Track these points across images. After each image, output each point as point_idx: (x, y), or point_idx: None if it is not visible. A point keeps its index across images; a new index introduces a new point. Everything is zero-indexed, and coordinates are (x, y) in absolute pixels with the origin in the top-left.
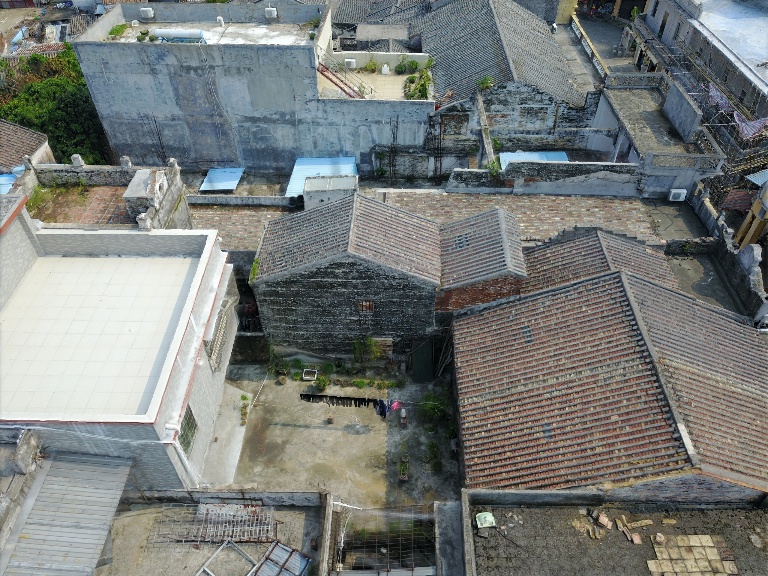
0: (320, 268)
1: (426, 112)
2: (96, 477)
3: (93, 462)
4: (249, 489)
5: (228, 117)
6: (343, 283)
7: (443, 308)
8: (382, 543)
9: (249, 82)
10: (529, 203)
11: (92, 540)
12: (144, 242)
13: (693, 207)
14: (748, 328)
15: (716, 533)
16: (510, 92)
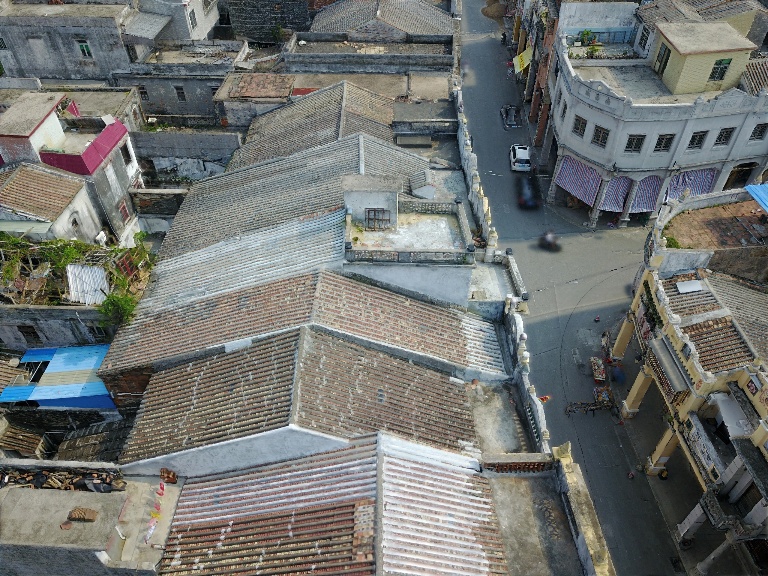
0: None
1: None
2: None
3: (158, 15)
4: None
5: None
6: None
7: (312, 8)
8: None
9: None
10: None
11: (158, 27)
12: None
13: None
14: (448, 16)
15: None
16: None
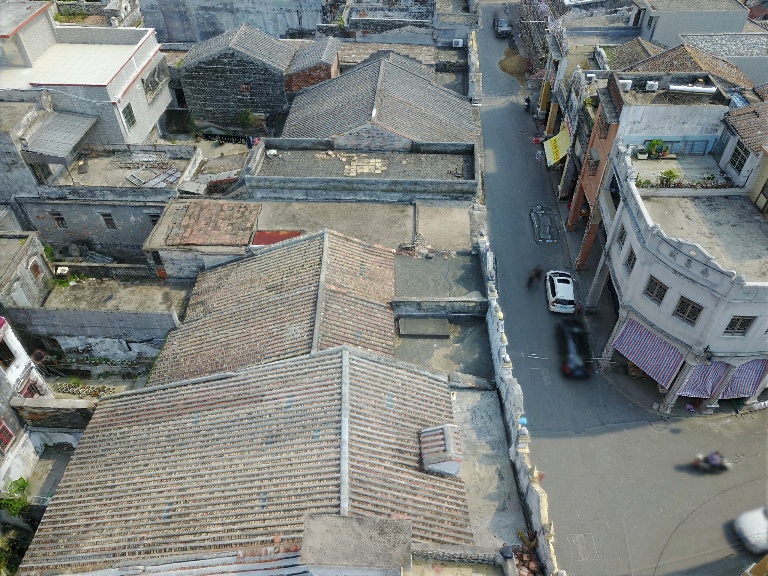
0: (215, 58)
1: (320, 3)
2: (79, 120)
3: (78, 115)
4: None
5: (189, 6)
6: (229, 69)
7: (290, 89)
8: (222, 166)
9: None
10: (363, 46)
11: (75, 137)
12: (114, 35)
13: (466, 50)
14: (464, 102)
15: (385, 159)
16: None
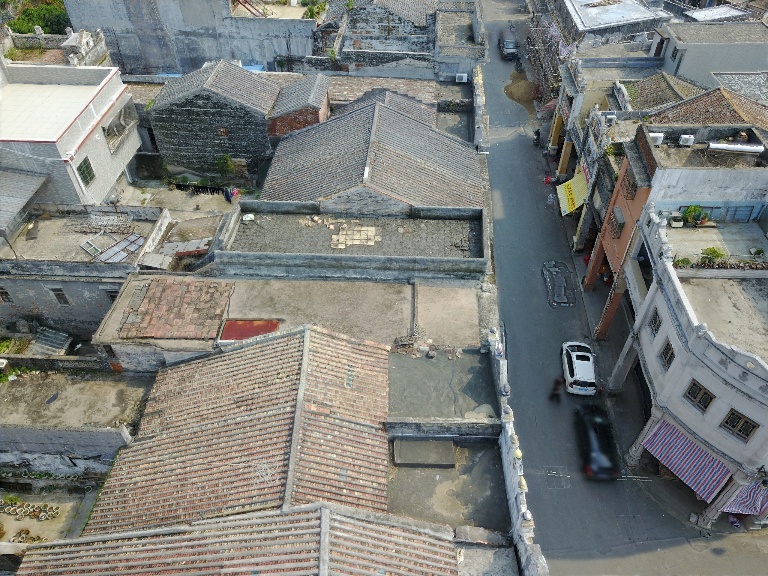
0: (188, 99)
1: (310, 28)
2: (26, 179)
3: (25, 174)
4: (119, 205)
5: (167, 31)
6: (205, 112)
7: (273, 134)
8: (191, 232)
9: (180, 3)
10: (357, 81)
11: (19, 202)
12: (74, 74)
13: (471, 86)
14: (470, 149)
15: (379, 226)
16: (369, 13)
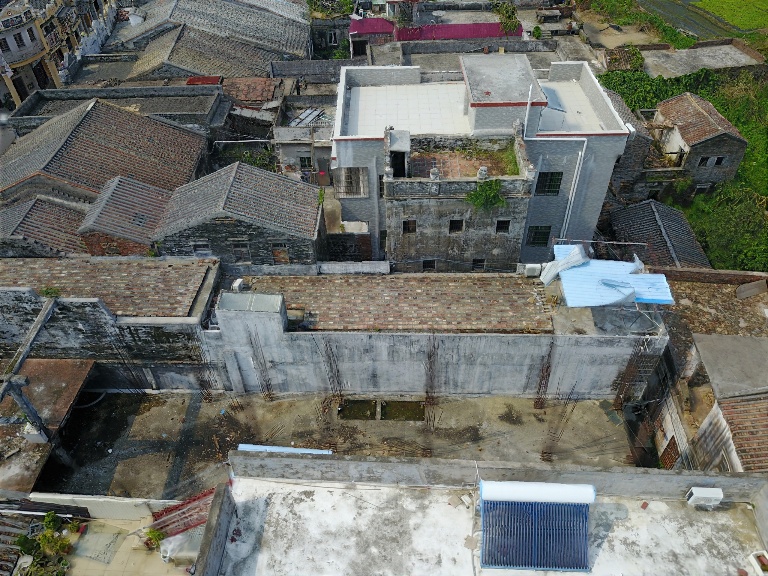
0: None
1: None
2: None
3: None
4: None
5: None
6: None
7: None
8: (252, 124)
9: None
10: None
11: None
12: None
13: None
14: None
15: None
16: None
